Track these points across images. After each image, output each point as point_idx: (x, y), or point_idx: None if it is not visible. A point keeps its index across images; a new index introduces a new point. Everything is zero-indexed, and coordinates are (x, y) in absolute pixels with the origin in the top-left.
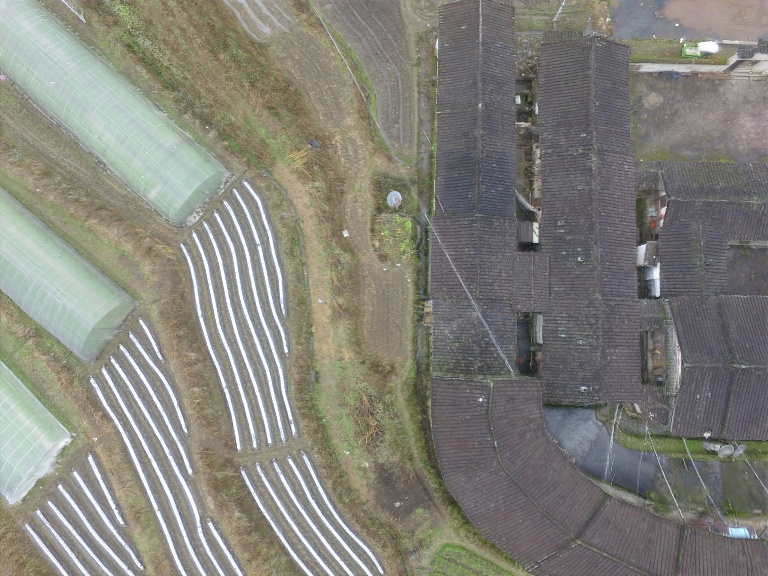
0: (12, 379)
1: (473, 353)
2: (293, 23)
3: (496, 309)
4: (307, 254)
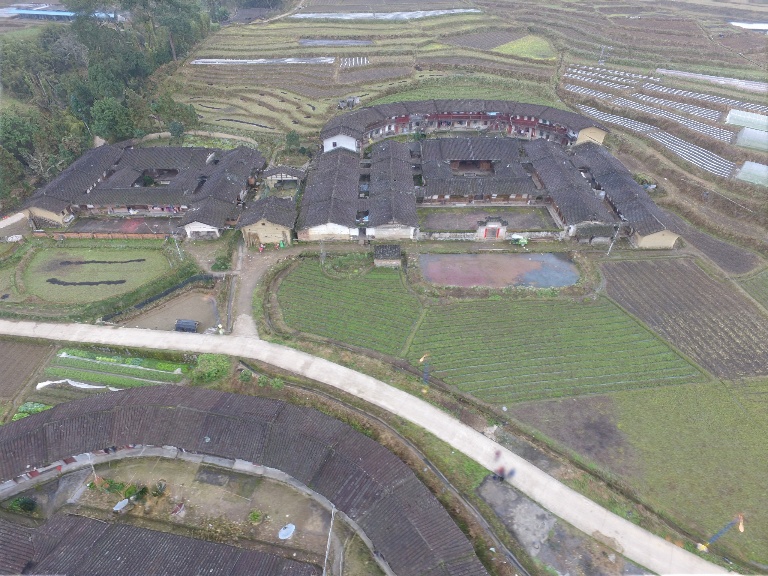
0: (761, 128)
1: (595, 146)
2: (761, 239)
3: (591, 155)
4: (679, 167)
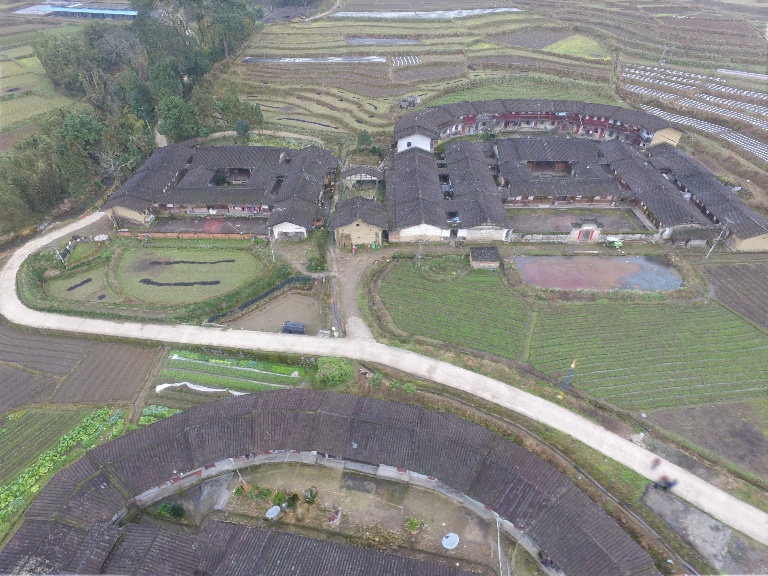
0: None
1: None
2: None
3: None
4: None
